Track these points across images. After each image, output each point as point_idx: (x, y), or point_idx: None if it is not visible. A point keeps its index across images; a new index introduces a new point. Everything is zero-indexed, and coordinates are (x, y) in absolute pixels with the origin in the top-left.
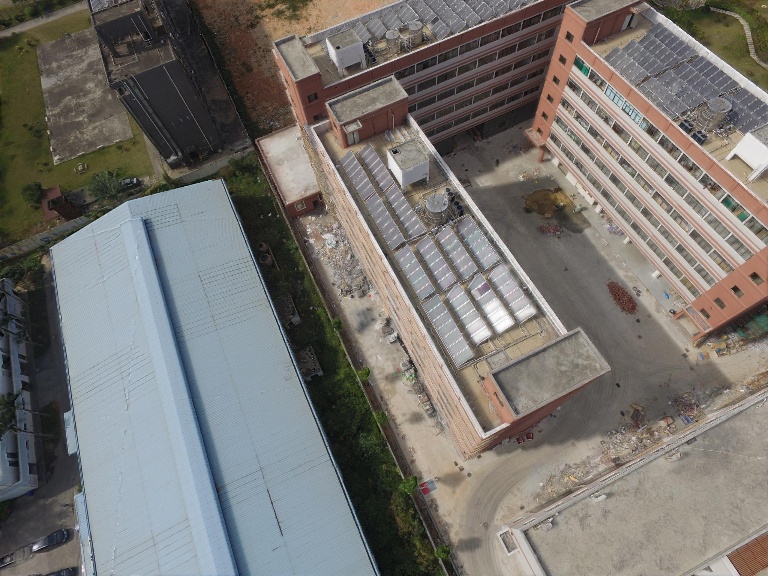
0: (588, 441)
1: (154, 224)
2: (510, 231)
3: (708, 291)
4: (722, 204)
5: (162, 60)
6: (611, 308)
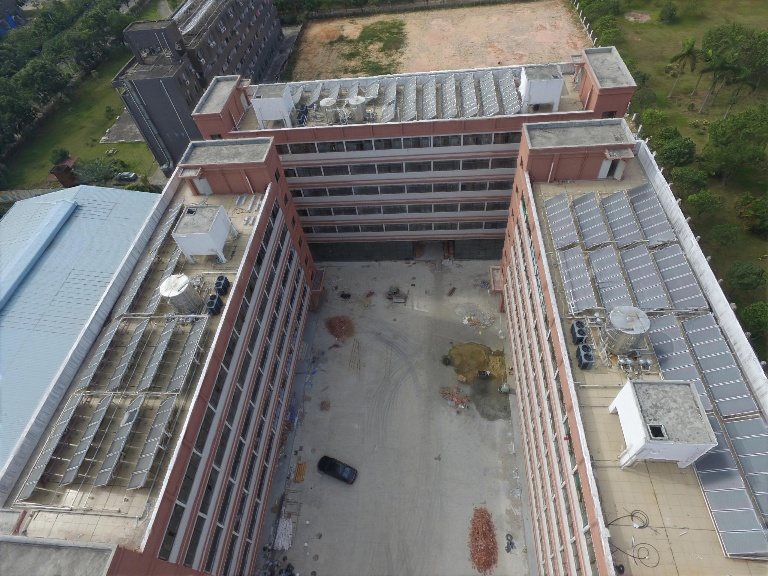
0: None
1: (82, 212)
2: (408, 375)
3: None
4: (573, 479)
5: (166, 75)
6: (458, 545)
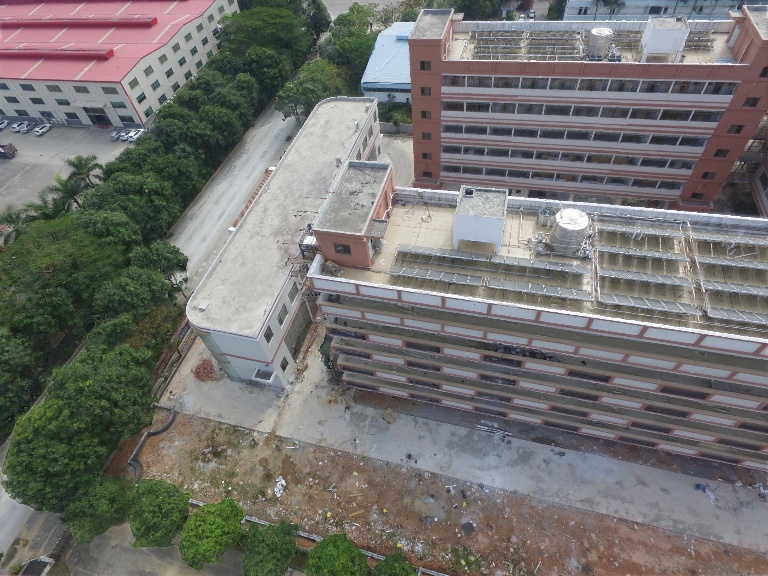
0: None
1: None
2: None
3: None
4: None
5: None
6: None
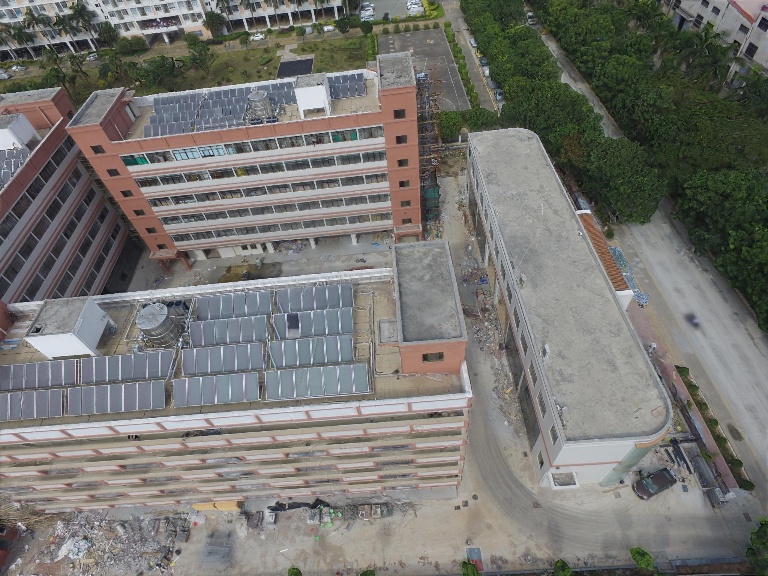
0: (477, 360)
1: None
2: None
3: (392, 205)
4: (335, 143)
5: None
6: None
